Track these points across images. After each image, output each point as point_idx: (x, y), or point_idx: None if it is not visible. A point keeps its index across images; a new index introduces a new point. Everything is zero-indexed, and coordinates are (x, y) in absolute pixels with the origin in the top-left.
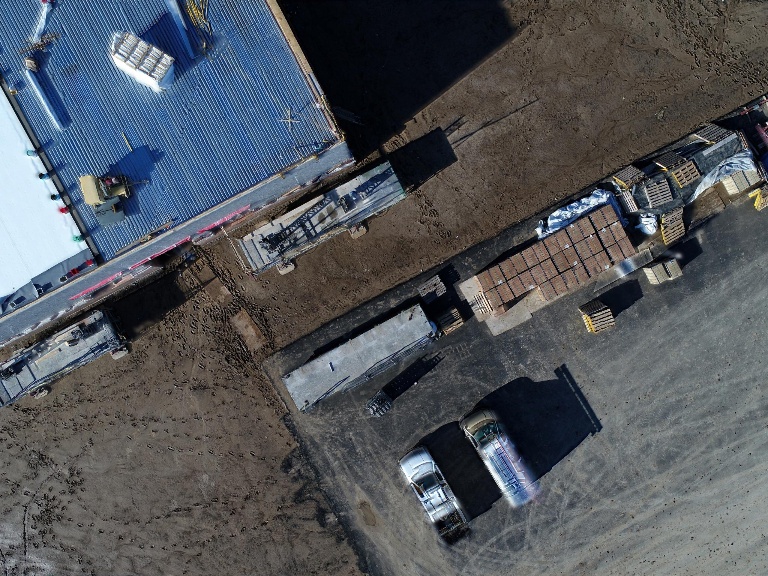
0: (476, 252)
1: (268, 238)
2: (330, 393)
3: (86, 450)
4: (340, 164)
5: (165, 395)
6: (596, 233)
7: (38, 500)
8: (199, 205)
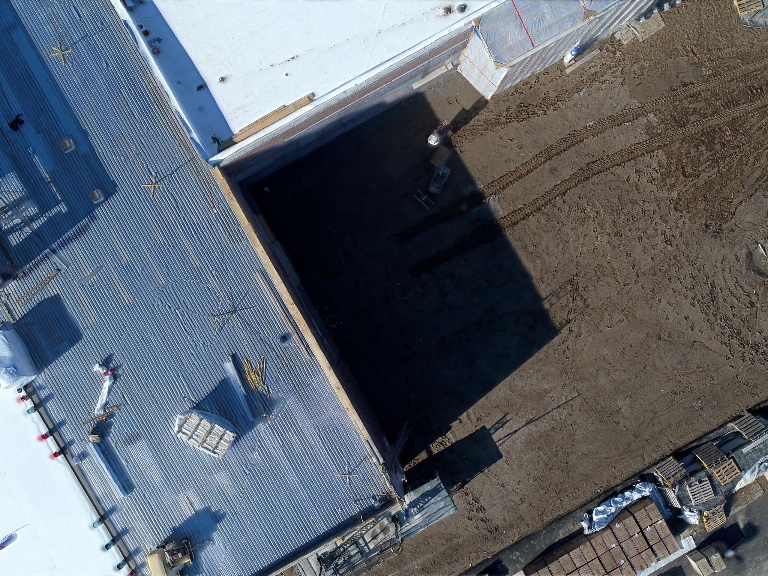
0: (523, 546)
1: (323, 557)
2: None
3: None
4: None
5: None
6: (641, 531)
7: None
8: (261, 561)
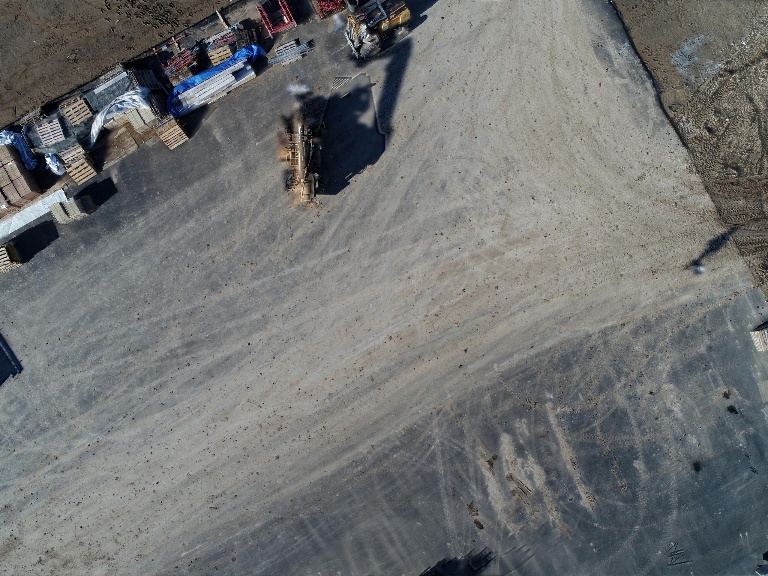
0: None
1: None
2: None
3: None
4: None
5: None
6: None
7: None
8: None
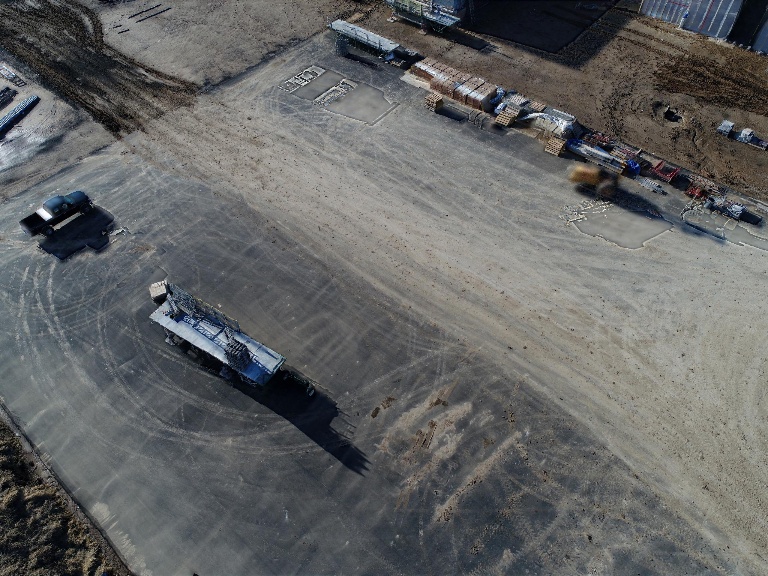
0: None
1: None
2: (340, 31)
3: None
4: (449, 8)
5: None
6: None
7: None
8: None
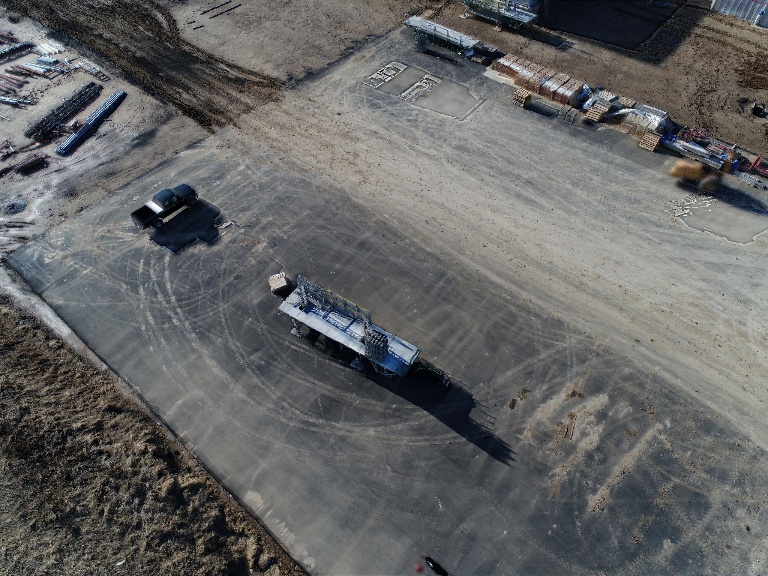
0: None
1: None
2: (417, 27)
3: None
4: (524, 5)
5: (381, 3)
6: None
7: None
8: None
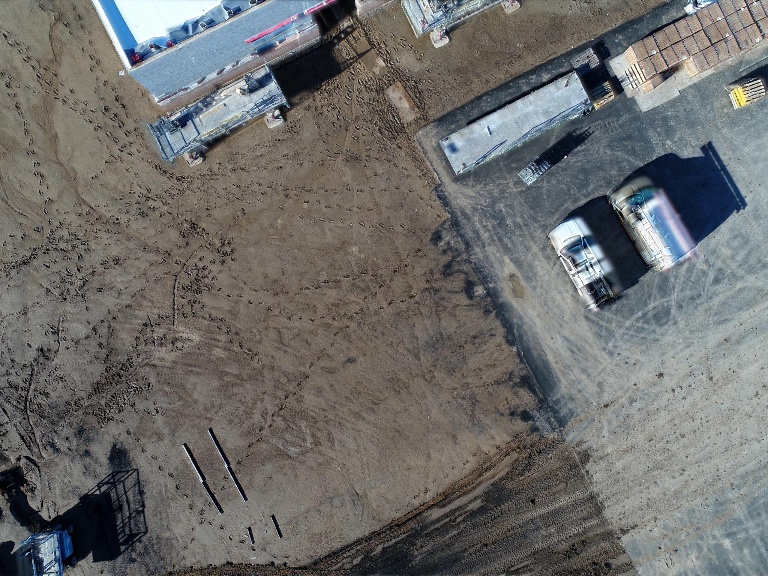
0: (626, 29)
1: None
2: (487, 157)
3: (238, 220)
4: None
5: (318, 166)
6: (747, 7)
7: (188, 269)
8: None
